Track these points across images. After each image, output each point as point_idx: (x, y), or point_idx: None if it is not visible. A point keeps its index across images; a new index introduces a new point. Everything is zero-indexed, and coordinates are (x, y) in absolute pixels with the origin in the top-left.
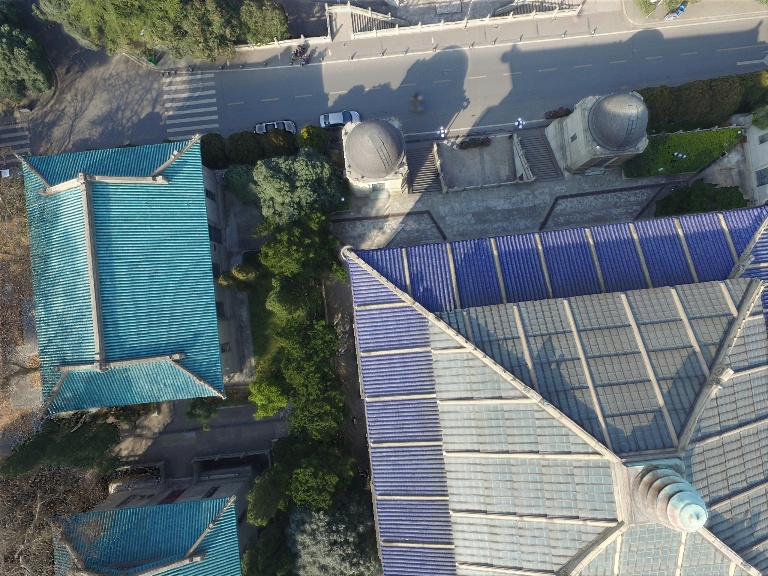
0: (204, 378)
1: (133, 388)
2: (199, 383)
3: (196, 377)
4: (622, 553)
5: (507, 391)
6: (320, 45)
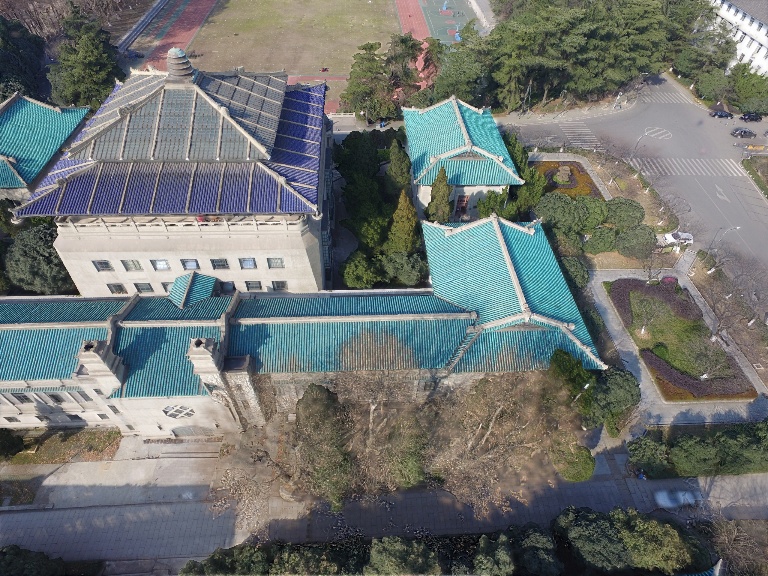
0: (21, 175)
1: None
2: (15, 172)
3: None
4: (164, 105)
5: None
6: None
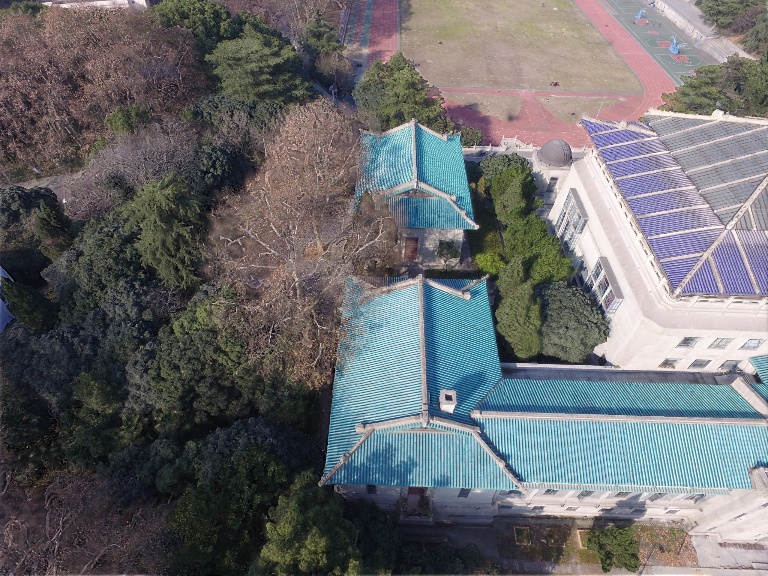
0: None
1: (417, 215)
2: None
3: (463, 210)
4: None
5: (701, 123)
6: (498, 152)
